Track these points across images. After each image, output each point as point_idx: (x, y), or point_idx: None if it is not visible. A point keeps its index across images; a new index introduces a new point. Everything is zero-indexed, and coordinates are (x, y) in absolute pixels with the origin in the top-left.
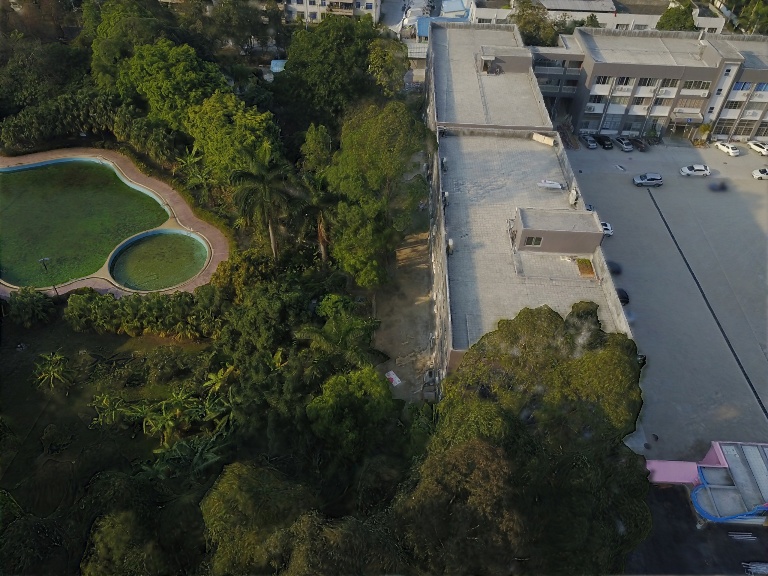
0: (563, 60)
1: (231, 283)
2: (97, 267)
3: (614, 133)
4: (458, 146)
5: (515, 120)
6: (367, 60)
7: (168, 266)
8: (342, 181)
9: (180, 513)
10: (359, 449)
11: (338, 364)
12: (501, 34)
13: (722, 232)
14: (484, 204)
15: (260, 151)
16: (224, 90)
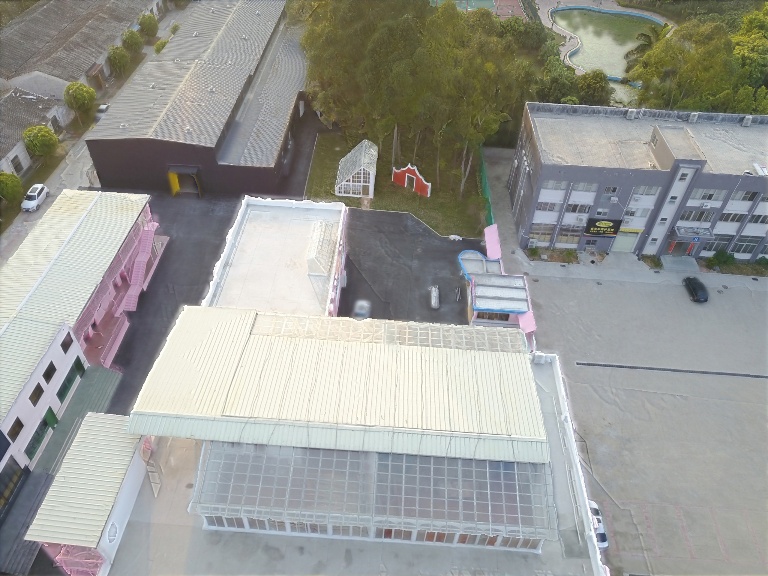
0: None
1: None
2: None
3: None
4: None
5: None
6: None
7: None
8: None
9: None
10: None
11: None
12: None
13: None
14: (704, 138)
15: (665, 28)
16: None
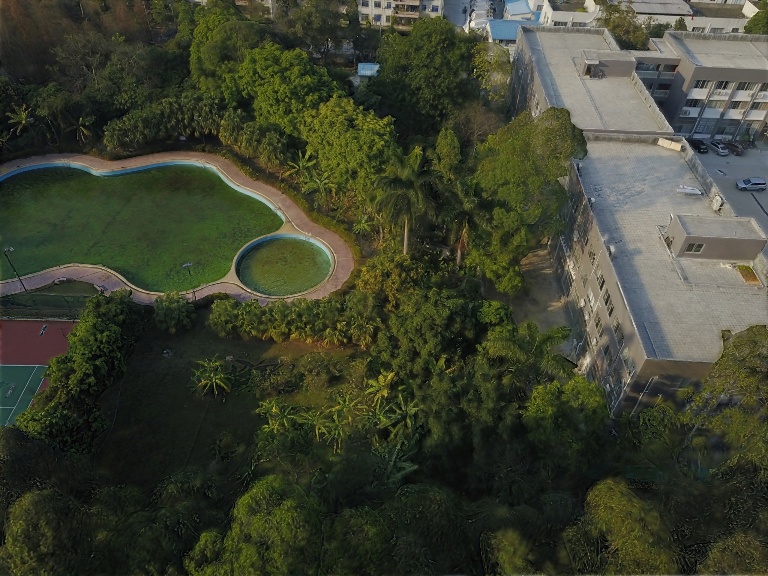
0: (658, 64)
1: (382, 289)
2: (223, 272)
3: (707, 137)
4: None
5: (631, 125)
6: (472, 64)
7: (293, 271)
8: (501, 187)
9: (499, 527)
10: (577, 459)
11: (531, 372)
12: (591, 38)
13: None
14: (628, 210)
15: (411, 157)
16: (338, 94)
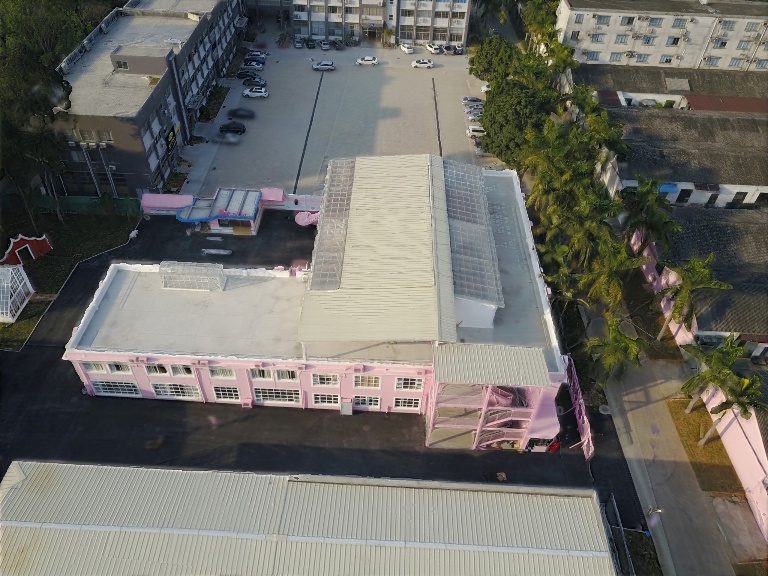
0: None
1: None
2: None
3: (323, 38)
4: (129, 21)
5: None
6: None
7: None
8: None
9: None
10: None
11: None
12: None
13: (356, 97)
14: None
15: None
16: None
